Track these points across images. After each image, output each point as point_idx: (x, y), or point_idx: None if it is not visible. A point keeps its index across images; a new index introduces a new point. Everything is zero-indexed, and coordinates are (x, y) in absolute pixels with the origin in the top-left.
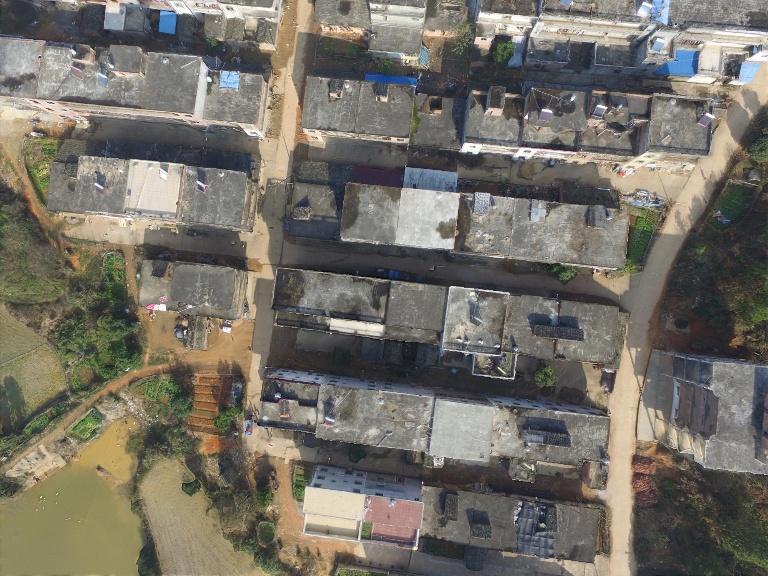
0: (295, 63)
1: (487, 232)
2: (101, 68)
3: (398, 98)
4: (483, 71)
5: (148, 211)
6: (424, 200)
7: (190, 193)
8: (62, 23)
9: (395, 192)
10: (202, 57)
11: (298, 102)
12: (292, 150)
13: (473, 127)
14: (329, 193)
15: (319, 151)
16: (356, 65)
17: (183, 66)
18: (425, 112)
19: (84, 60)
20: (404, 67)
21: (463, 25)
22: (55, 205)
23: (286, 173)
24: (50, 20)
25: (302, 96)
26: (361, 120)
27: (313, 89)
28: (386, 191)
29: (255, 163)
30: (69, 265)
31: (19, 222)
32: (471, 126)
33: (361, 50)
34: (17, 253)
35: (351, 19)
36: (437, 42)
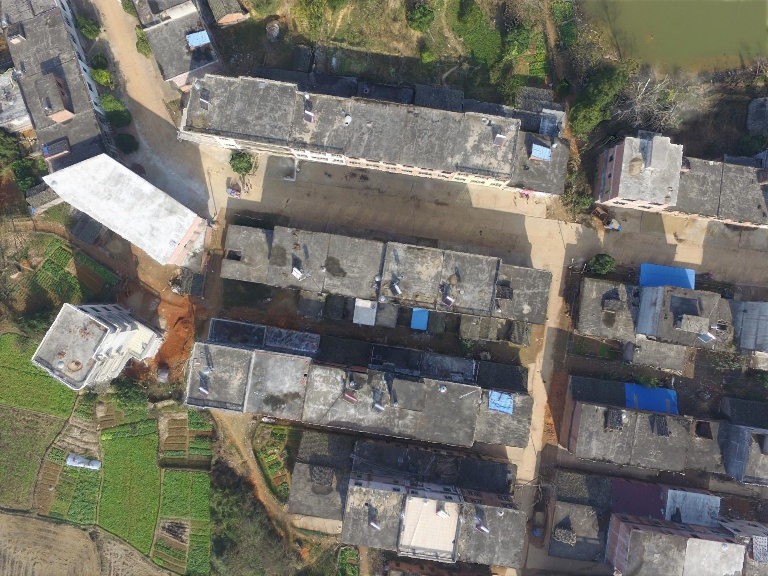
0: (544, 359)
1: (763, 575)
2: (373, 393)
3: (674, 431)
4: (737, 381)
5: (423, 549)
6: (710, 551)
7: (467, 531)
8: (307, 313)
9: (681, 542)
10: (458, 360)
11: (547, 400)
12: (540, 450)
13: (750, 466)
14: (592, 514)
15: (569, 455)
16: (607, 365)
17: (462, 396)
18: (691, 436)
19: (361, 390)
20: (657, 371)
21: (729, 345)
22: (297, 508)
23: (533, 474)
24: (283, 296)
25: (551, 394)
26: (637, 452)
27: (588, 418)
28: (672, 540)
29: (512, 474)
30: (300, 559)
31: (252, 519)
32: (747, 465)
33: (613, 351)
34: (244, 545)
35: (616, 331)
36: (690, 347)
